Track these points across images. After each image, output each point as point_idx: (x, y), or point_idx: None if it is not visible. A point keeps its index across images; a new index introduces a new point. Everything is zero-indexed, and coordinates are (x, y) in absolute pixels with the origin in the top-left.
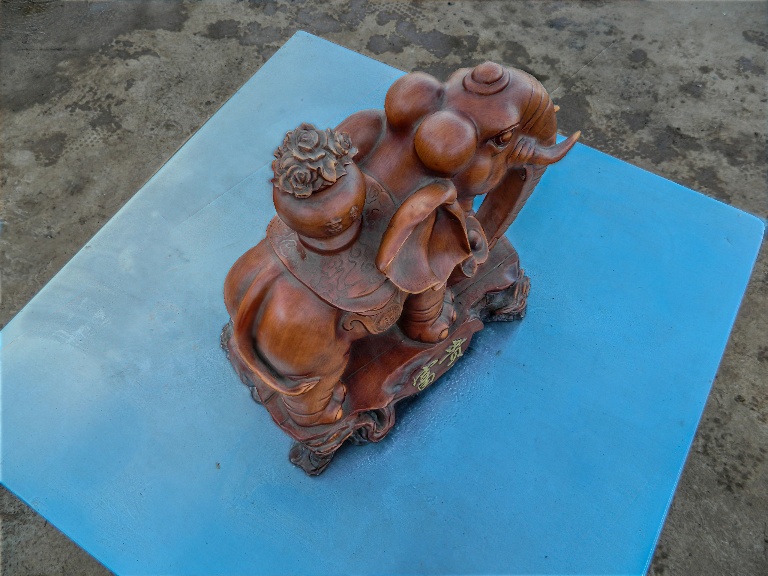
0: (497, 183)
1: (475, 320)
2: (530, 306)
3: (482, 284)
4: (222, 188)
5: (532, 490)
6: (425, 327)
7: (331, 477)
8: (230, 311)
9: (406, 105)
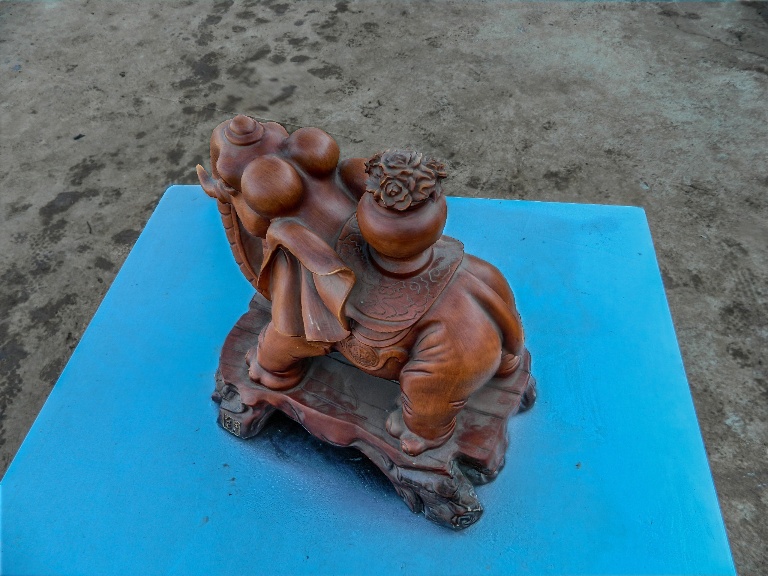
0: None
1: None
2: None
3: None
4: None
5: None
6: None
7: None
8: None
9: (292, 170)
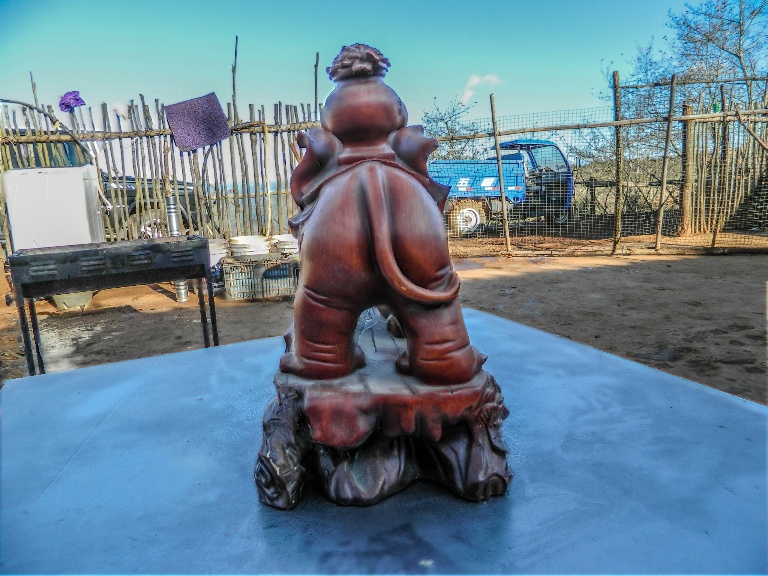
0: None
1: None
2: None
3: None
4: (63, 456)
5: None
6: None
7: (519, 481)
8: (352, 235)
9: None
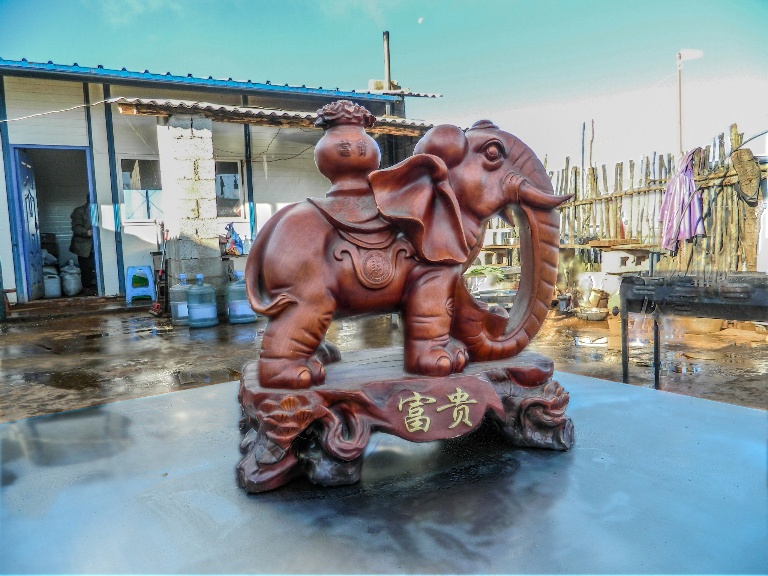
0: (494, 202)
1: (489, 384)
2: (579, 446)
3: (505, 365)
4: None
5: (525, 554)
6: (424, 348)
7: (269, 499)
8: None
9: None
